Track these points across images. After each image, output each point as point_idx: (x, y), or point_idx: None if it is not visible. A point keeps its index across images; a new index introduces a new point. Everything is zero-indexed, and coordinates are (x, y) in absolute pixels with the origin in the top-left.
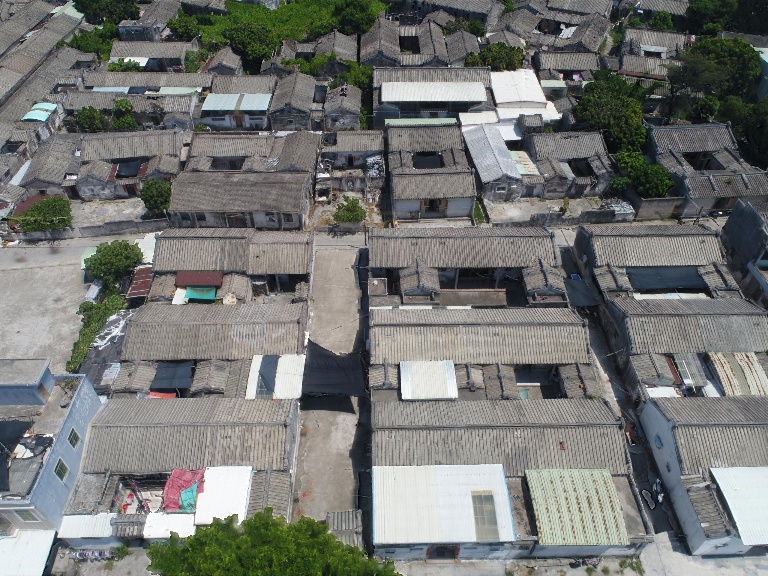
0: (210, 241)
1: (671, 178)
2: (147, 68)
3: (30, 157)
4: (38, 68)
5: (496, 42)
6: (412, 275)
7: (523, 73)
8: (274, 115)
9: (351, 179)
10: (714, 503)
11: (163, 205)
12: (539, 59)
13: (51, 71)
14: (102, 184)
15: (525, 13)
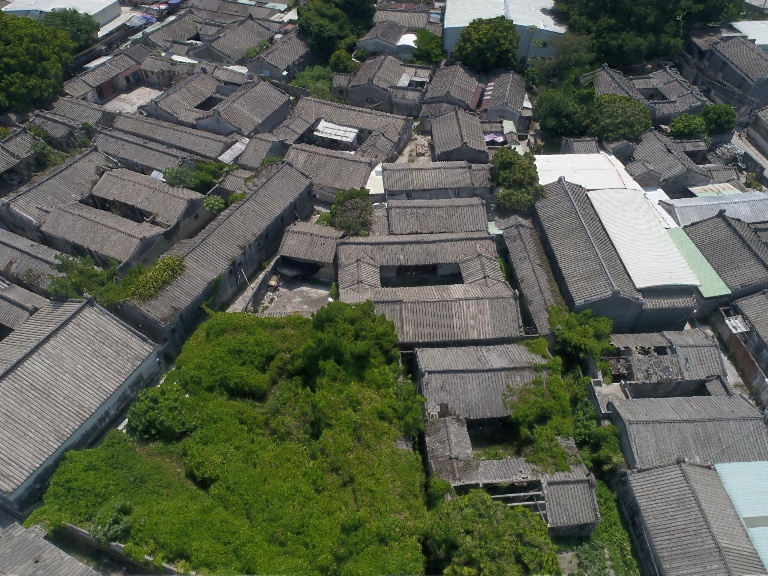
0: None
1: (689, 113)
2: None
3: None
4: None
5: (414, 182)
6: None
7: None
8: None
9: None
10: None
11: None
12: (476, 150)
13: None
14: None
15: (303, 148)
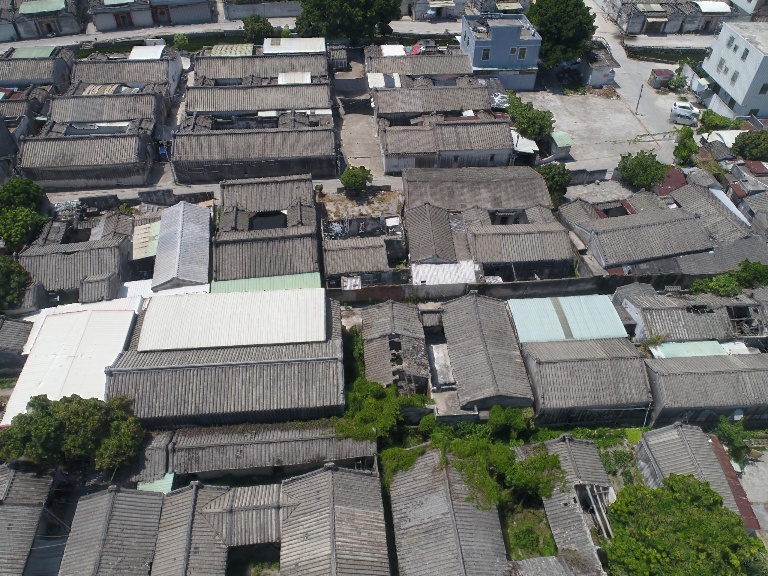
0: None
1: None
2: None
3: None
4: None
5: None
6: None
7: None
8: None
9: (361, 220)
10: (168, 53)
11: None
12: None
13: None
14: None
15: None
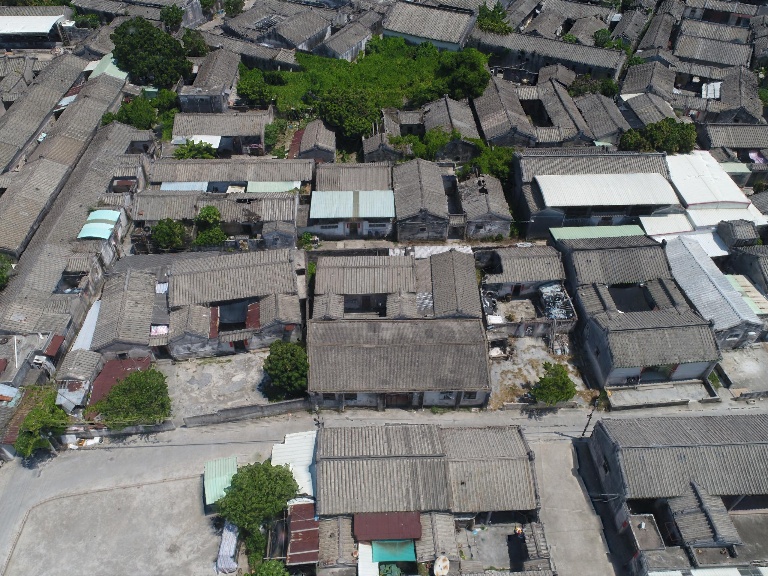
0: (393, 461)
1: None
2: (219, 148)
3: (92, 290)
4: (84, 153)
5: (642, 108)
6: (694, 513)
7: (700, 157)
8: (403, 223)
9: (532, 324)
10: None
11: (298, 382)
12: (707, 134)
13: (103, 160)
14: (202, 341)
15: (659, 67)
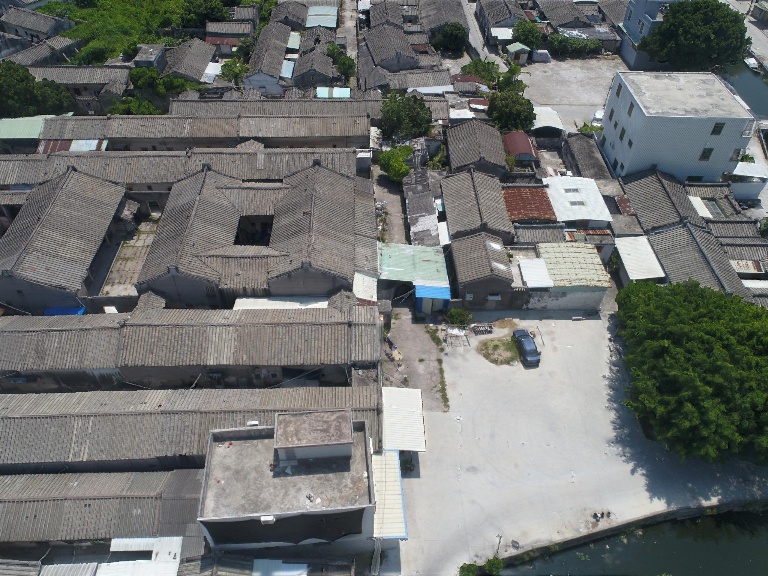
0: (508, 5)
1: None
2: None
3: None
4: None
5: None
6: None
7: None
8: None
9: None
10: None
11: None
12: None
13: None
14: None
15: None
